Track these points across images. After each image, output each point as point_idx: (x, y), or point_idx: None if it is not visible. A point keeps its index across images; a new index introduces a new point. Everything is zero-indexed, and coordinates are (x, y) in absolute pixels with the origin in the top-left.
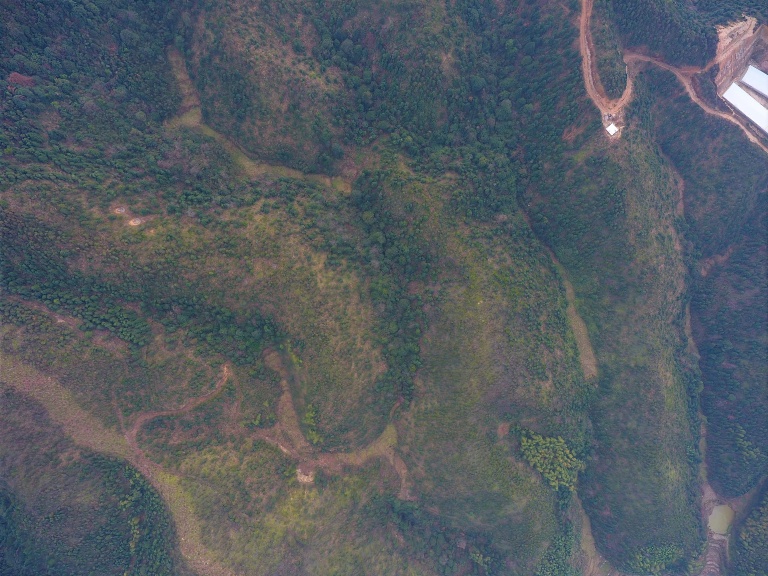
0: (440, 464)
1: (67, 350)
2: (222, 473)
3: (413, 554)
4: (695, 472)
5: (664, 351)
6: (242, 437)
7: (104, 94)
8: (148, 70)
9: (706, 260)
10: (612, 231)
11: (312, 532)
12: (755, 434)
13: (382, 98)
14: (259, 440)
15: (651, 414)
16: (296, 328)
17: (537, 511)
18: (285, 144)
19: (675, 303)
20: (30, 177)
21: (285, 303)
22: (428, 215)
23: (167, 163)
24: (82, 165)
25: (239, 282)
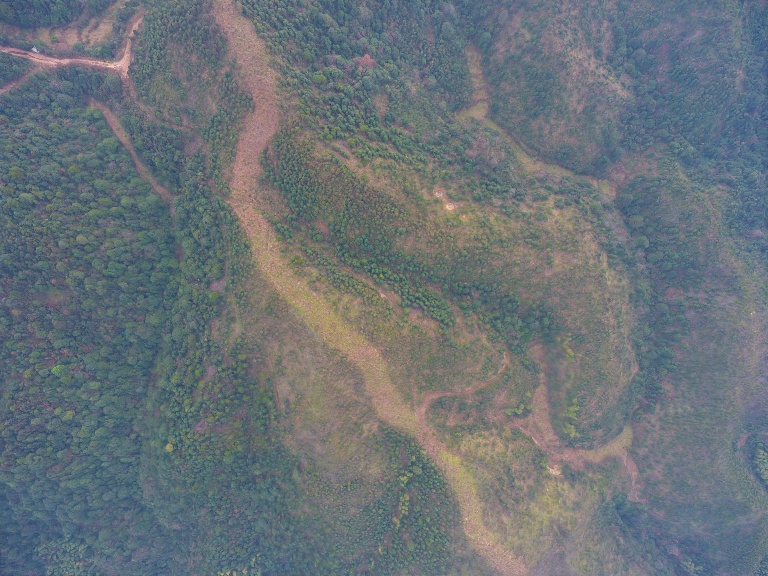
0: (685, 469)
1: (391, 324)
2: (495, 458)
3: (632, 556)
4: None
5: None
6: (502, 425)
7: (418, 82)
8: (456, 62)
9: None
10: None
11: (574, 524)
12: None
13: (663, 107)
14: (517, 429)
15: None
16: (578, 322)
17: (765, 524)
18: (568, 144)
19: None
20: (381, 155)
21: (574, 297)
22: (709, 224)
23: (471, 153)
24: (411, 148)
25: (537, 273)
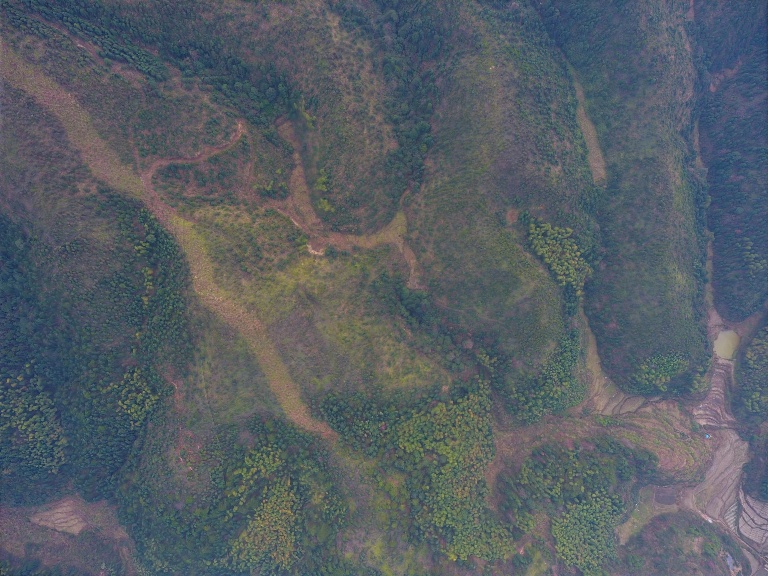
0: (449, 242)
1: (87, 71)
2: (235, 226)
3: (420, 348)
4: (701, 288)
5: (673, 148)
6: (254, 204)
7: None
8: None
9: (715, 75)
10: (623, 17)
11: (322, 289)
12: (762, 245)
13: None
14: (271, 208)
15: (659, 210)
16: (310, 84)
17: (544, 301)
18: None
19: (684, 110)
20: None
21: (300, 55)
22: None
23: None
24: None
25: (255, 29)
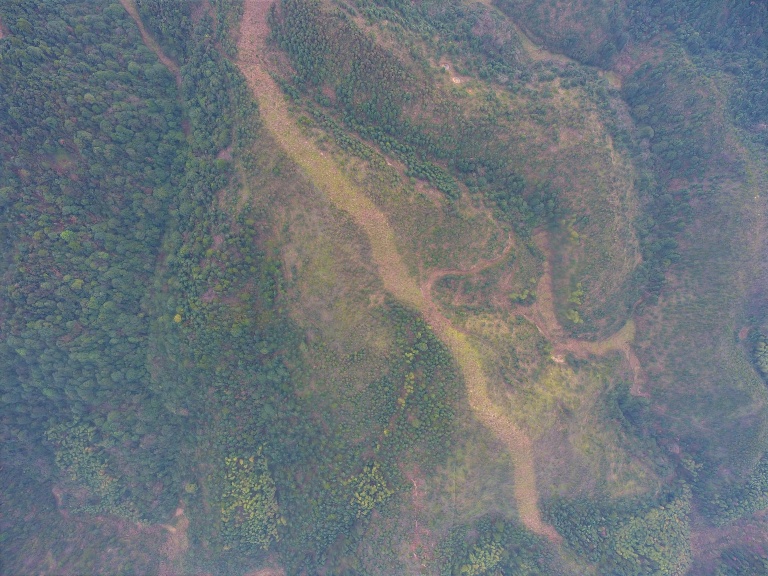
0: (687, 358)
1: (398, 191)
2: (499, 337)
3: (634, 451)
4: None
5: None
6: (506, 311)
7: None
8: None
9: None
10: None
11: (578, 404)
12: None
13: None
14: (521, 316)
15: None
16: (583, 204)
17: (765, 417)
18: (574, 30)
19: None
20: (388, 17)
21: (579, 176)
22: (714, 107)
23: (477, 32)
24: (417, 18)
25: (543, 150)
